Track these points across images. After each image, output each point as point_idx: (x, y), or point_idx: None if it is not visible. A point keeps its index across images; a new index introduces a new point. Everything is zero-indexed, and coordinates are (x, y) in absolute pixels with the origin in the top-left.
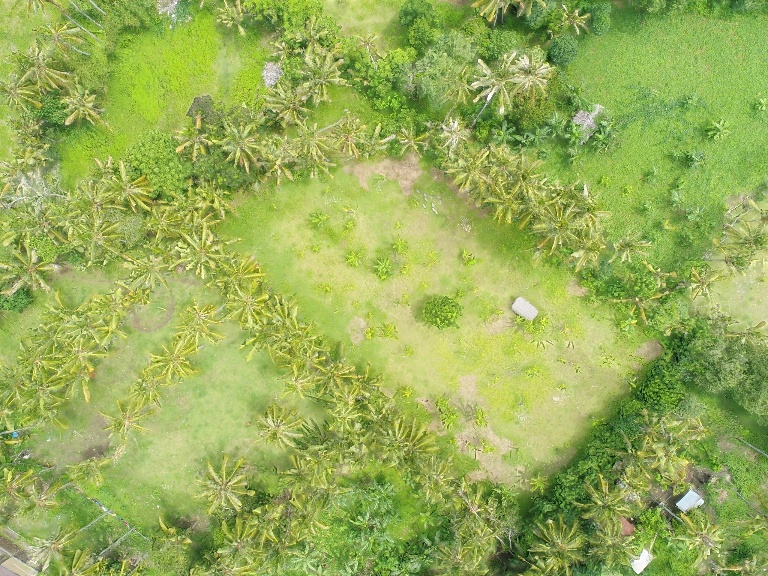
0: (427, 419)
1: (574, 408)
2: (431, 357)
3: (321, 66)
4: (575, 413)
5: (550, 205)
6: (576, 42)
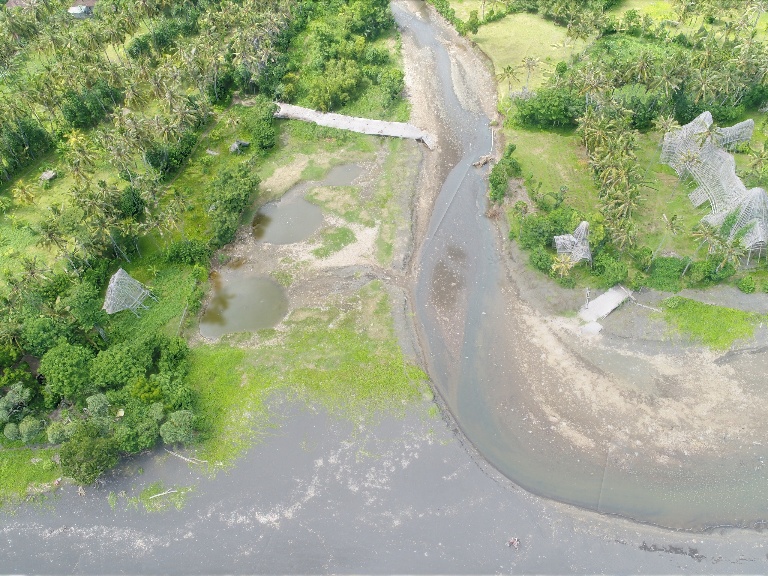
0: None
1: (630, 7)
2: None
3: None
4: (628, 6)
5: None
6: None
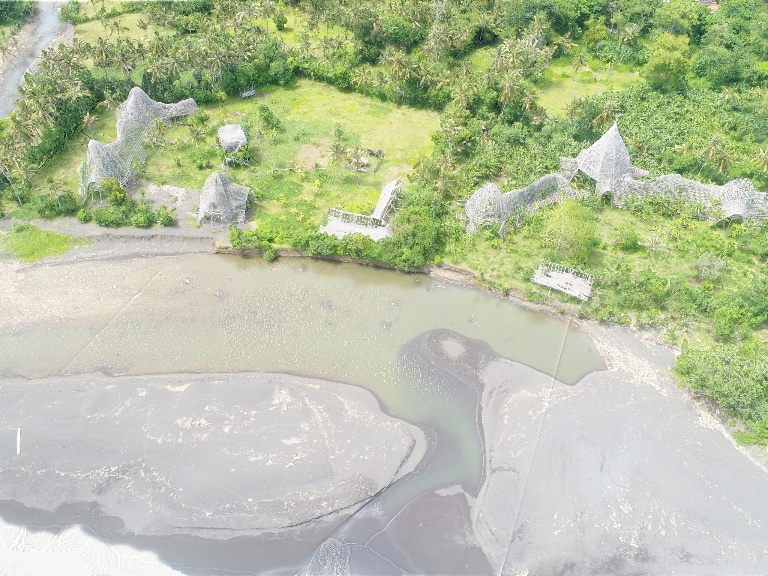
0: None
1: None
2: None
3: None
4: None
5: (234, 6)
6: None
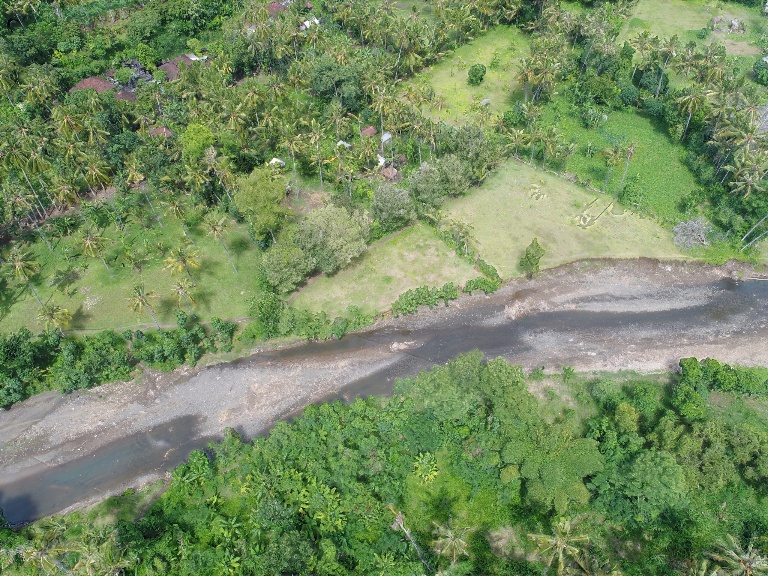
0: (417, 82)
1: None
2: (450, 82)
3: (587, 31)
4: None
5: None
6: (635, 91)
